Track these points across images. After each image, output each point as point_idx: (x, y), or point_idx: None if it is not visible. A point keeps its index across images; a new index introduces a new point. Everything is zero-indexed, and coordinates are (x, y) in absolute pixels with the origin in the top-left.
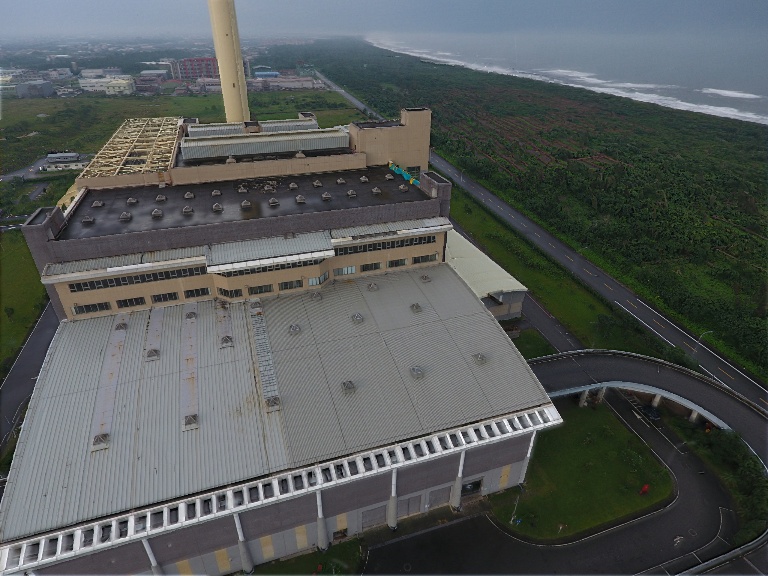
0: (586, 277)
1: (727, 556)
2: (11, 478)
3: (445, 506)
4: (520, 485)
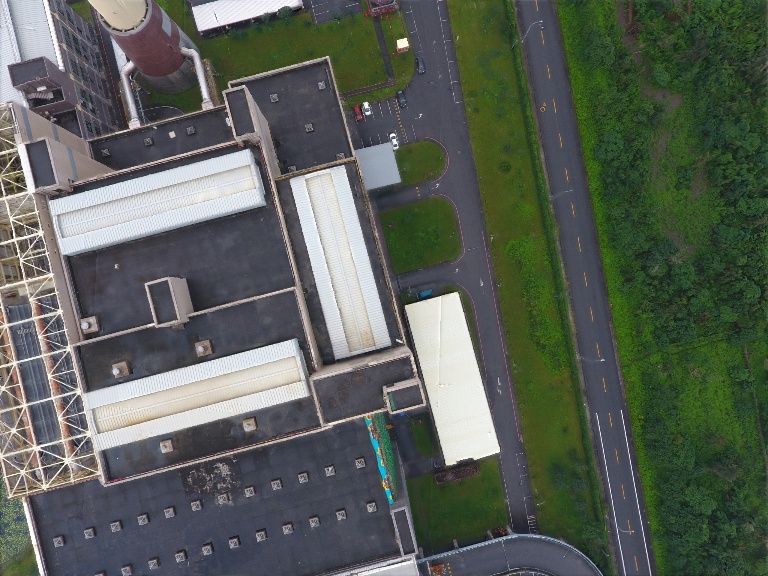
0: (590, 363)
1: None
2: None
3: None
4: None
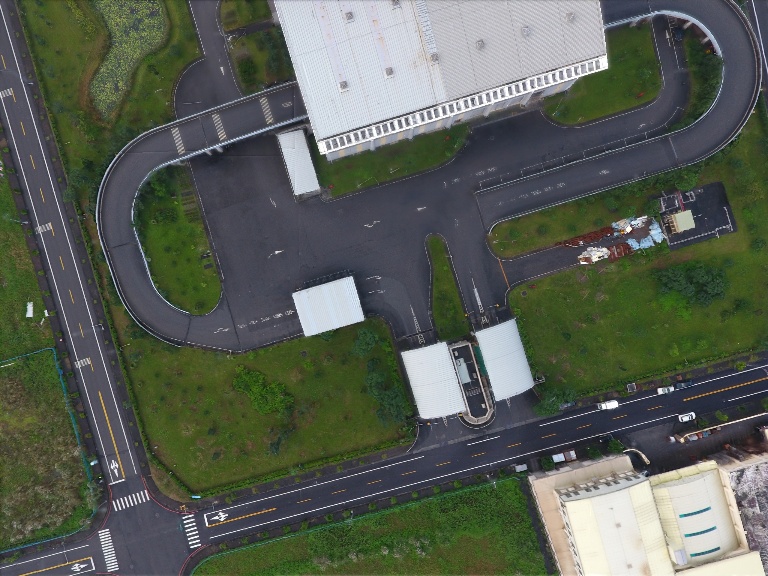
0: None
1: (661, 137)
2: (308, 108)
3: (517, 104)
4: (565, 91)
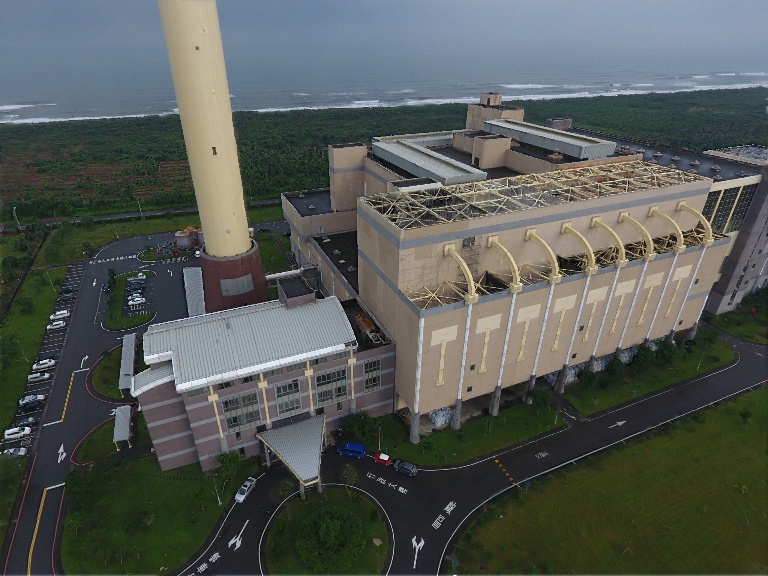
0: None
1: None
2: None
3: None
4: None
